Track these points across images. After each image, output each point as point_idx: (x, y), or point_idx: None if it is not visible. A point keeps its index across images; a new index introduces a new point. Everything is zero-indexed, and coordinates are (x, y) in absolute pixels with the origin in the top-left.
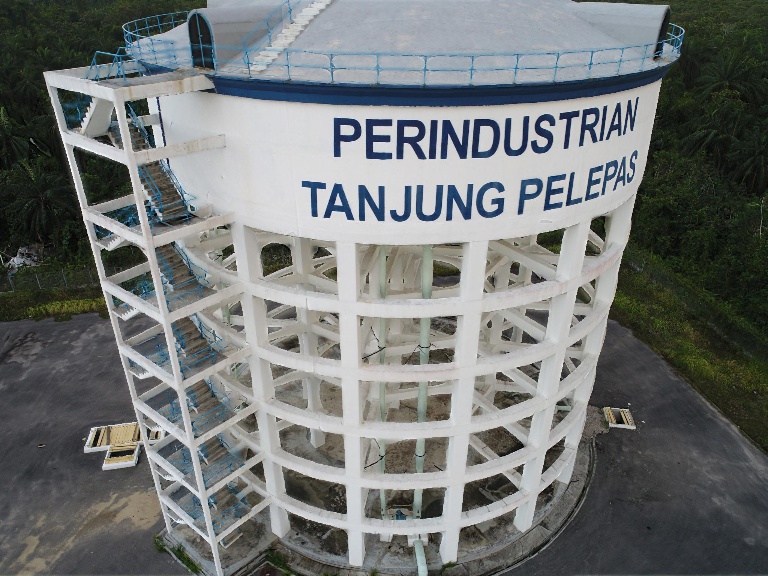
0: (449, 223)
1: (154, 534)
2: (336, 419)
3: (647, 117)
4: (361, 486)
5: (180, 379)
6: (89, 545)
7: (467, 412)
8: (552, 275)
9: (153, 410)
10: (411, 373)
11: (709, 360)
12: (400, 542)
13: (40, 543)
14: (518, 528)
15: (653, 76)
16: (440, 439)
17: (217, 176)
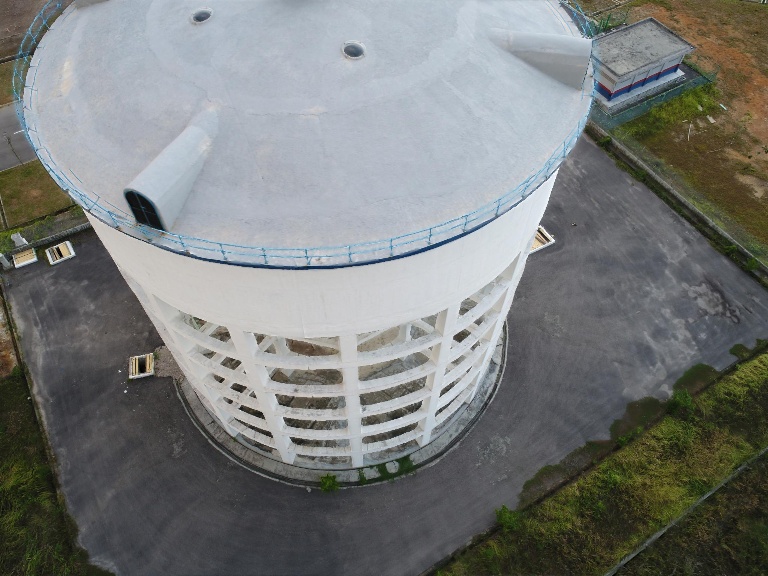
0: None
1: None
2: None
3: None
4: None
5: None
6: None
7: None
8: None
9: None
10: None
11: (1, 502)
12: None
13: None
14: None
15: None
16: None
17: None
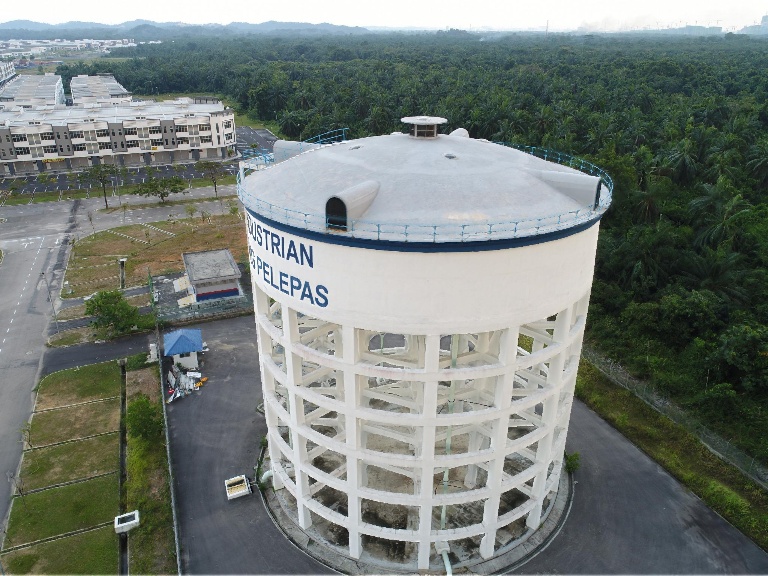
0: None
1: None
2: None
3: (336, 269)
4: None
5: None
6: None
7: None
8: None
9: None
10: None
11: None
12: None
13: None
14: None
15: (314, 236)
16: (382, 475)
17: None
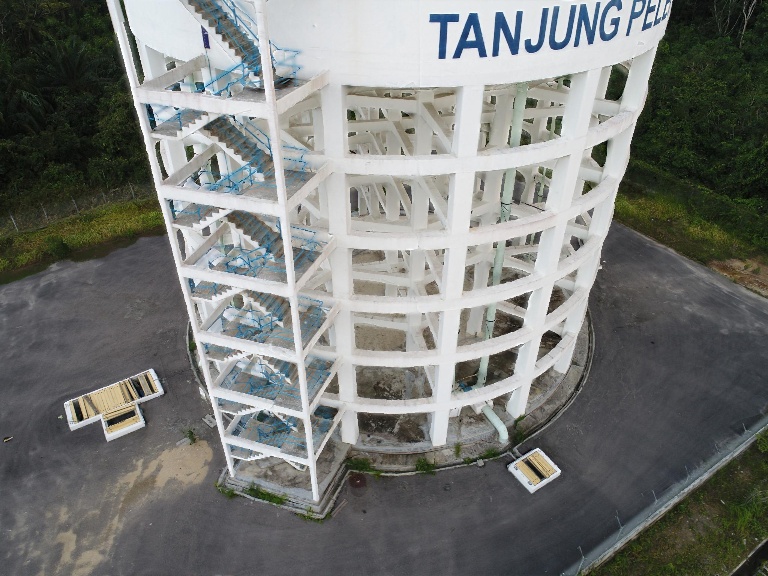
0: (575, 50)
1: (213, 484)
2: (434, 297)
3: None
4: (455, 361)
5: (294, 282)
6: (142, 518)
7: (556, 260)
8: (614, 109)
9: (229, 336)
10: (518, 227)
11: (626, 201)
12: (467, 413)
13: (78, 536)
14: (559, 371)
15: None
16: None
17: (304, 26)
